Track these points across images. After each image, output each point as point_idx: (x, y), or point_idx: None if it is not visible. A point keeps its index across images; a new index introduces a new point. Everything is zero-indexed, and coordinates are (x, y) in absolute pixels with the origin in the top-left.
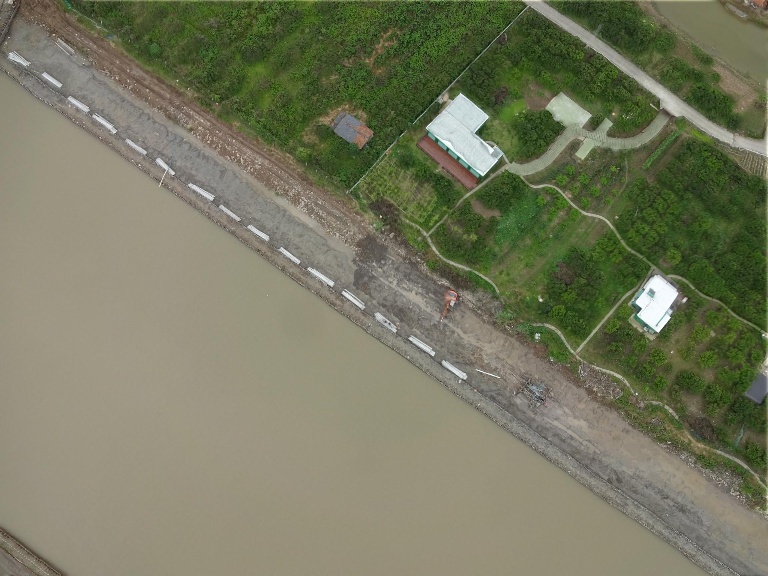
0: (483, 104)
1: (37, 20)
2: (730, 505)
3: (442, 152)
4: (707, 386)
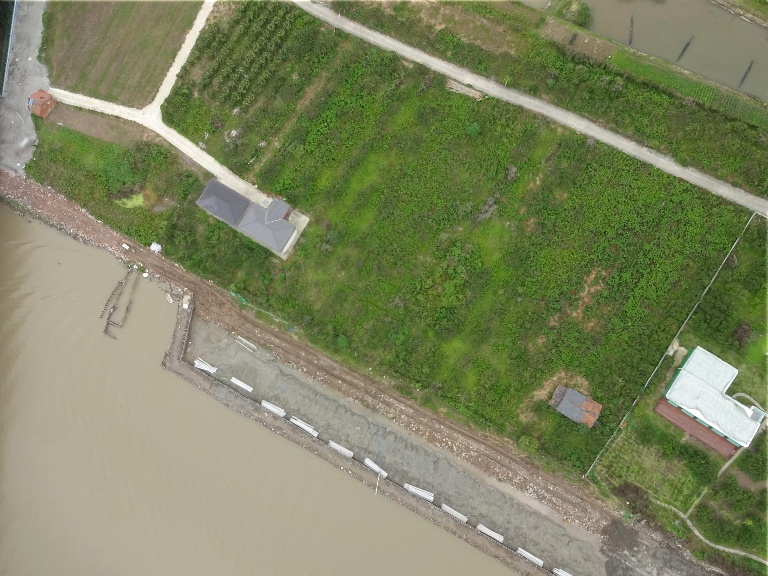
0: (723, 347)
1: (214, 319)
2: None
3: (686, 416)
4: None
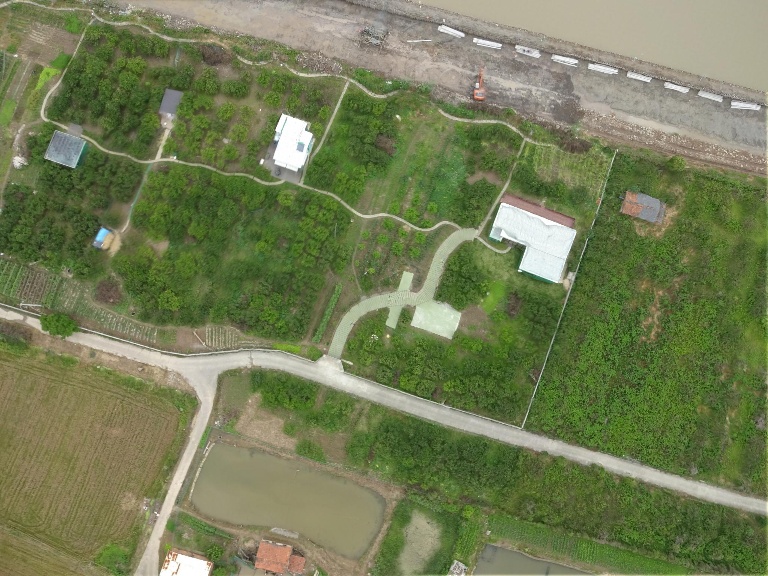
0: None
1: None
2: (169, 7)
3: None
4: (221, 87)
